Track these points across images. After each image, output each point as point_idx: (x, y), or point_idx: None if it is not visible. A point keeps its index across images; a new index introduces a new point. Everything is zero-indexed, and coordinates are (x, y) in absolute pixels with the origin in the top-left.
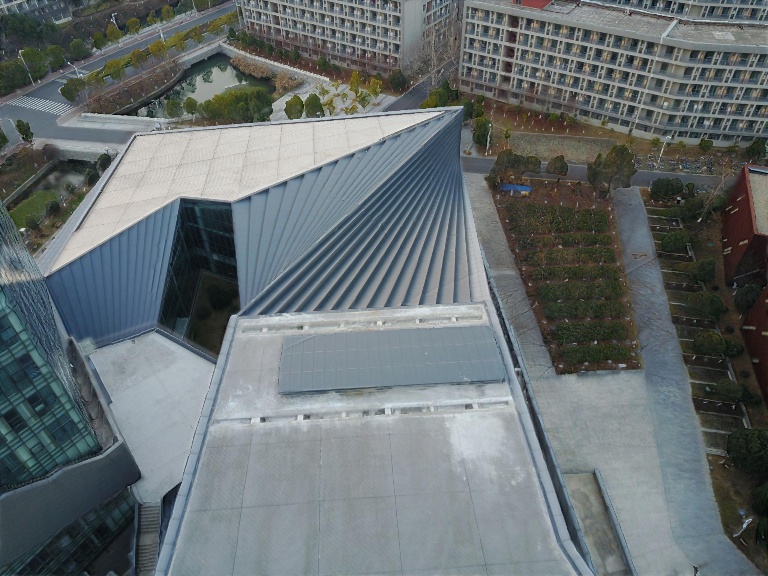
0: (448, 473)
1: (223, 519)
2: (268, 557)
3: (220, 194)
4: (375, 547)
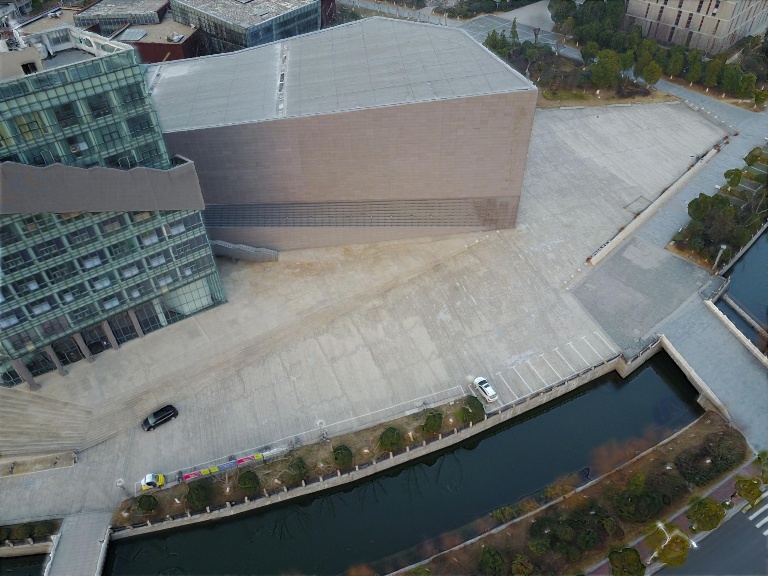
0: (193, 75)
1: (194, 119)
2: (217, 105)
3: None
4: (221, 85)
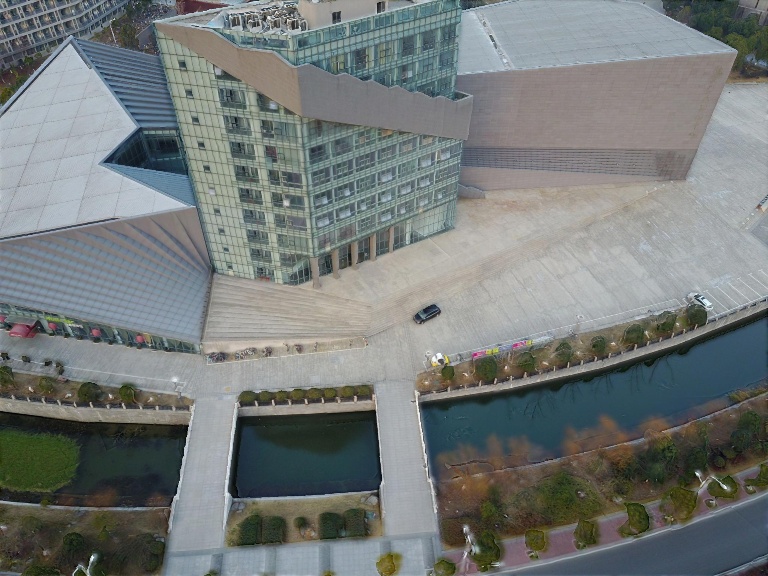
0: None
1: None
2: None
3: (118, 137)
4: None
